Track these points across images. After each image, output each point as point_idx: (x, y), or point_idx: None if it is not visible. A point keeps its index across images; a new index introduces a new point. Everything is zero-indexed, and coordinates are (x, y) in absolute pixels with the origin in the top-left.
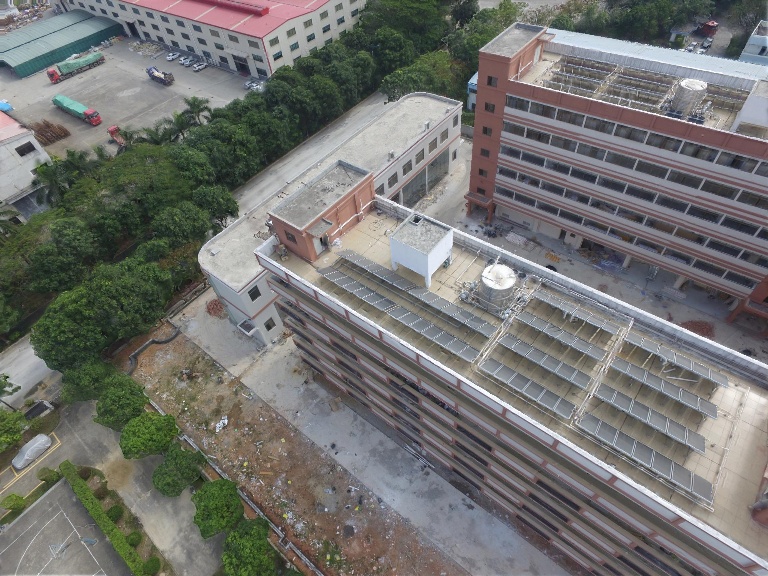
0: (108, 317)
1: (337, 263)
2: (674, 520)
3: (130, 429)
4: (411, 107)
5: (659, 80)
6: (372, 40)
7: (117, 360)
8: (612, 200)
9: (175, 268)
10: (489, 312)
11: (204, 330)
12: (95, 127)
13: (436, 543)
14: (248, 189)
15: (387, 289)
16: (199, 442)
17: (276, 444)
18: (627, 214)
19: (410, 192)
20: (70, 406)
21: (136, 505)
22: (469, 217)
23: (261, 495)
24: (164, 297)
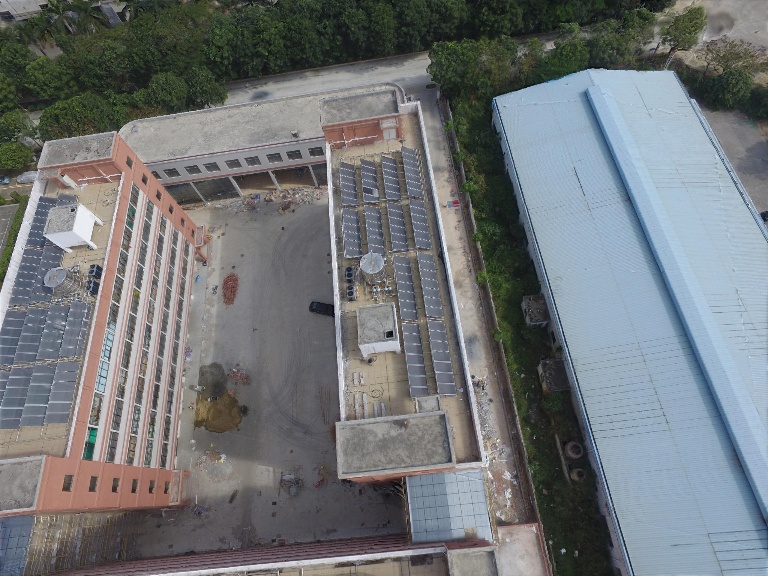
0: None
1: None
2: None
3: None
4: None
5: None
6: None
7: None
8: None
9: None
10: None
11: None
12: None
13: None
14: (274, 81)
15: None
16: None
17: None
18: None
19: None
20: None
21: None
22: None
23: None
24: None
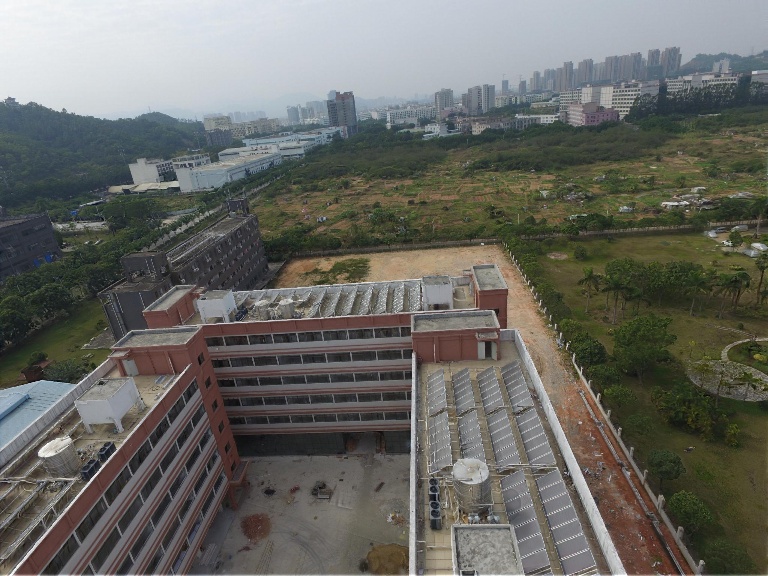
0: None
1: None
2: None
3: None
4: None
5: None
6: None
7: None
8: None
9: None
10: None
11: None
12: None
13: None
14: None
15: None
16: None
17: None
18: None
19: None
20: None
21: None
22: None
23: None
24: None
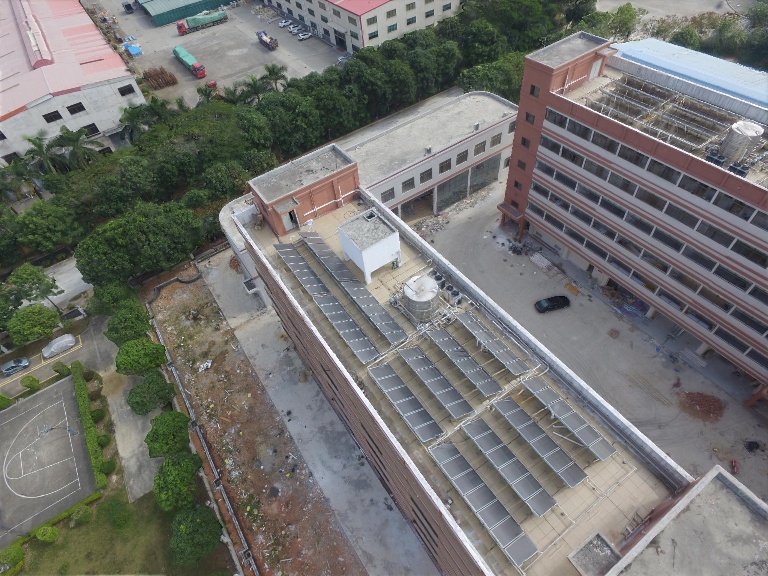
0: (137, 249)
1: (300, 242)
2: (481, 571)
3: (125, 348)
4: (470, 105)
5: (722, 117)
6: (465, 31)
7: (145, 288)
8: (638, 241)
9: (207, 218)
10: (410, 321)
11: (221, 280)
12: (199, 80)
13: (345, 529)
14: None
15: (330, 276)
16: (182, 376)
17: (242, 397)
18: (654, 260)
19: (447, 191)
20: (99, 317)
21: (117, 413)
22: (501, 228)
23: (214, 437)
24: (192, 242)
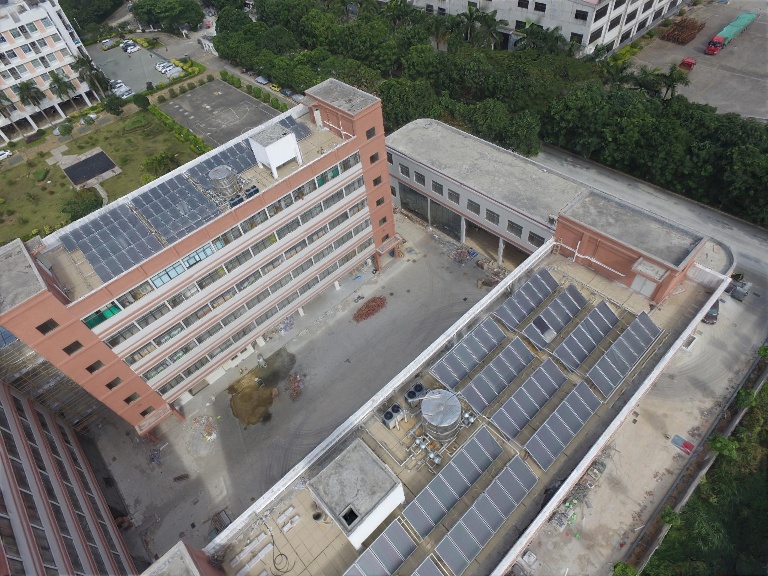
0: None
1: None
2: None
3: None
4: None
5: None
6: None
7: None
8: None
9: None
10: None
11: None
12: (703, 54)
13: None
14: (599, 171)
15: None
16: None
17: None
18: None
19: None
20: None
21: None
22: None
23: None
24: None
